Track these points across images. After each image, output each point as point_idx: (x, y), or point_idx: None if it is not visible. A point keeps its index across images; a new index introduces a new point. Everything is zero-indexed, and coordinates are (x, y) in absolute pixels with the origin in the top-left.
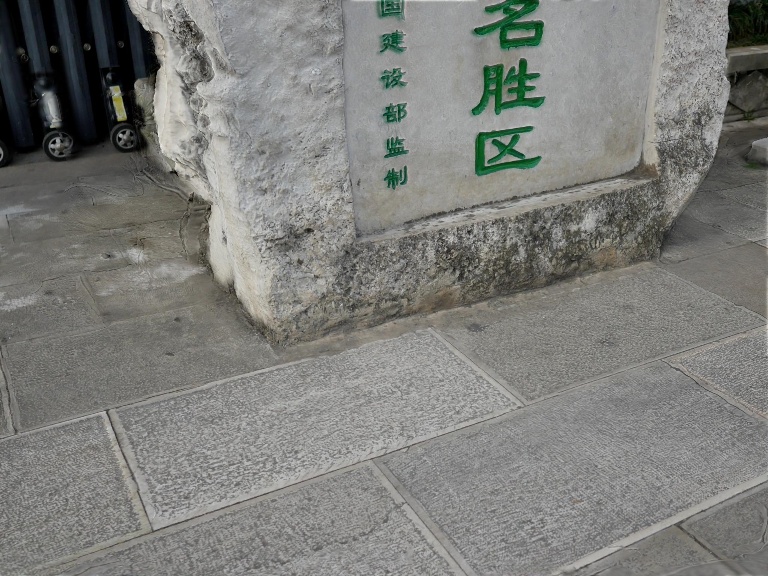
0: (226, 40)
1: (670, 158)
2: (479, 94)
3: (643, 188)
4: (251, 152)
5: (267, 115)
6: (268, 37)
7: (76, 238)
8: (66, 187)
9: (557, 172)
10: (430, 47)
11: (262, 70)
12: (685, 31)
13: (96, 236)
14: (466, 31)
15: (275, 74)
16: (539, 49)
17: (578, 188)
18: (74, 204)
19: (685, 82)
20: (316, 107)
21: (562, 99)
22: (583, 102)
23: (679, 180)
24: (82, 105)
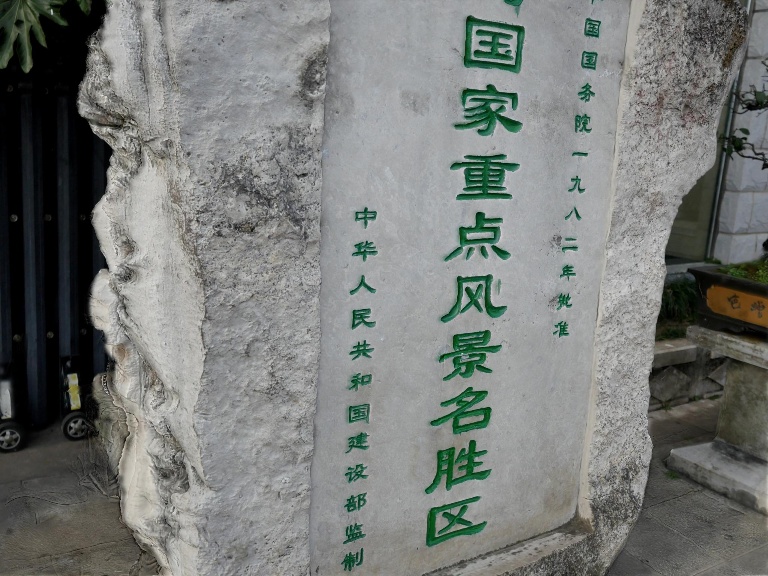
0: (205, 464)
1: (603, 513)
2: (432, 475)
3: (579, 545)
4: (218, 559)
5: (236, 523)
6: (244, 456)
7: (15, 570)
8: (8, 497)
9: (501, 533)
10: (390, 442)
11: (236, 484)
12: (613, 403)
13: (37, 567)
14: (423, 425)
15: (247, 486)
16: (487, 431)
17: (520, 546)
18: (16, 524)
19: (614, 443)
20: (283, 511)
21: (506, 469)
22: (525, 470)
23: (611, 532)
24: (33, 397)
